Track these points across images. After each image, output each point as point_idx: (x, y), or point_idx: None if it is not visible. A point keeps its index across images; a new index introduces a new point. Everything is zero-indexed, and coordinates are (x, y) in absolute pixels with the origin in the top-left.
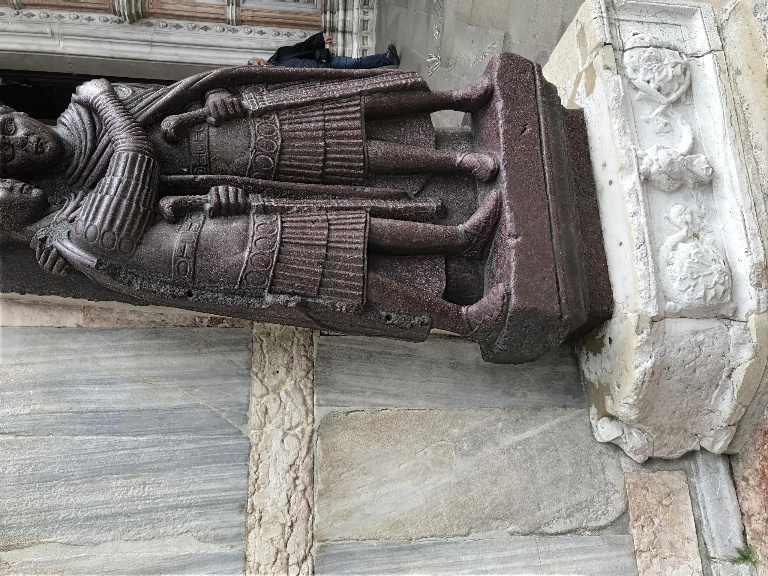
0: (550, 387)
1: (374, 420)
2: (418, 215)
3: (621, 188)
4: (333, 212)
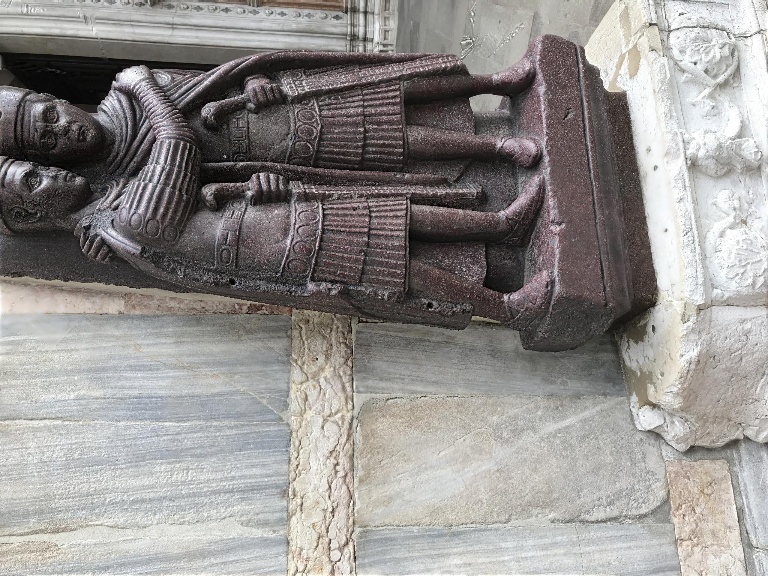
0: (590, 375)
1: (413, 407)
2: (458, 201)
3: (667, 173)
4: (373, 199)
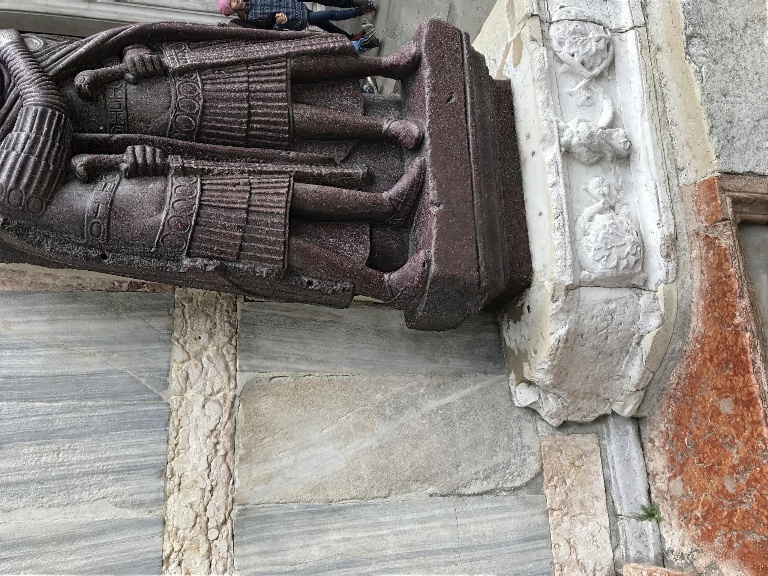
0: (472, 354)
1: (297, 386)
2: (344, 181)
3: (542, 159)
4: (256, 176)
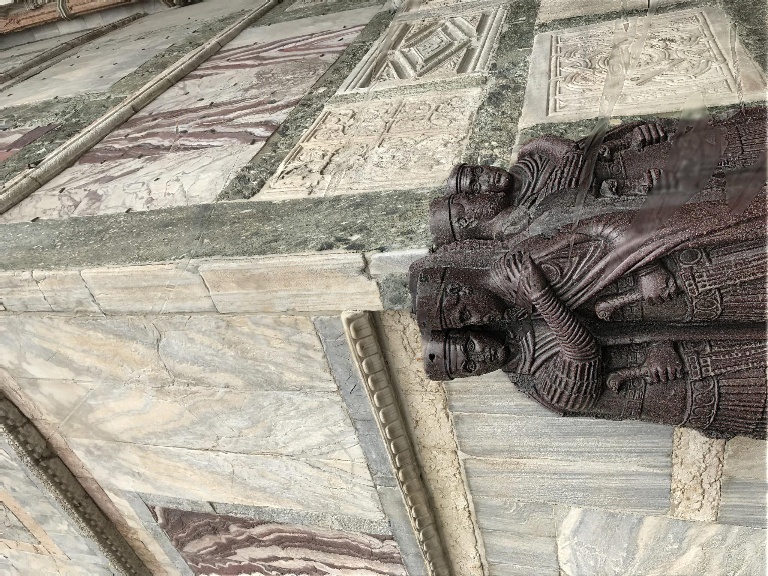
0: None
1: None
2: None
3: None
4: None
